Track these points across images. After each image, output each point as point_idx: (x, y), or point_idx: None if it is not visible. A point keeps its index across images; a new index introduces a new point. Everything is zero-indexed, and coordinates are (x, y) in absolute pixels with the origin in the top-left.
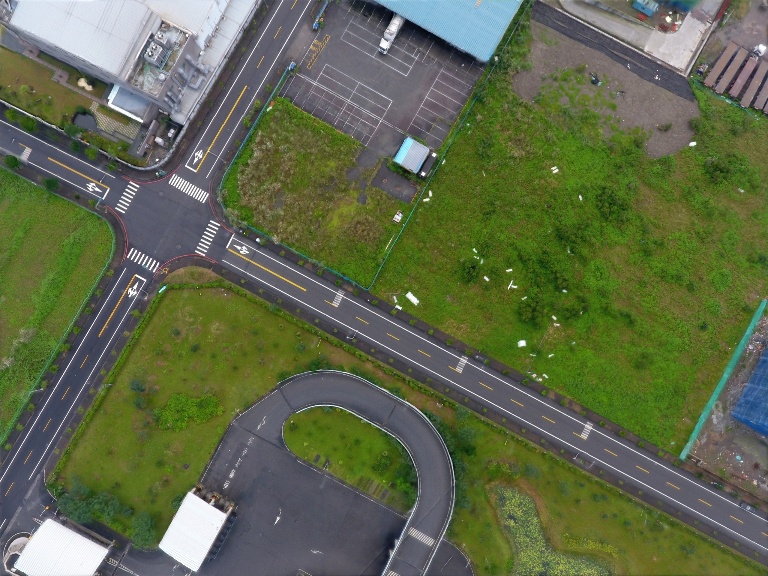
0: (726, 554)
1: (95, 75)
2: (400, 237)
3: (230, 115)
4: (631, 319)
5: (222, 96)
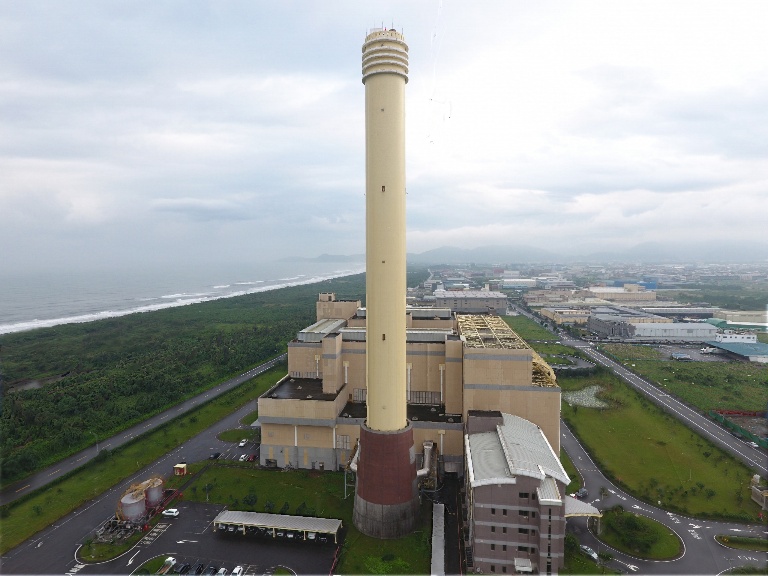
0: None
1: (597, 331)
2: None
3: None
4: None
5: None
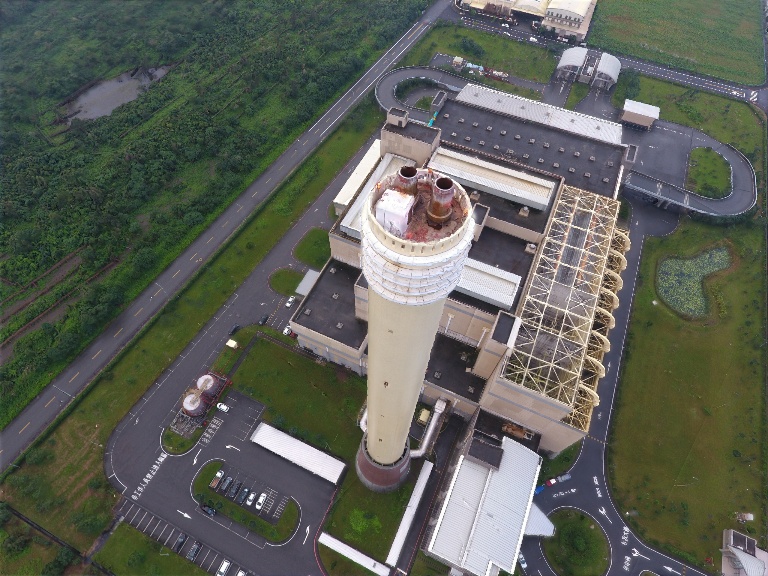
0: (761, 398)
1: None
2: None
3: None
4: None
5: None
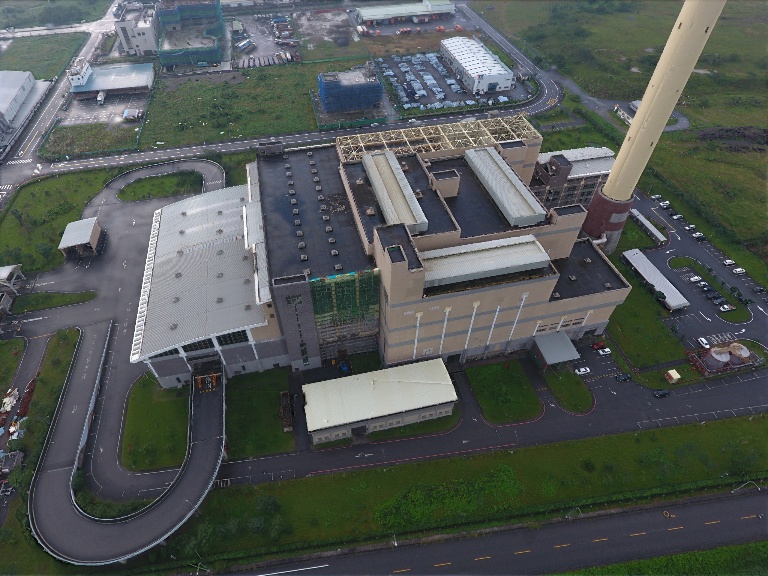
0: None
1: None
2: (142, 132)
3: (33, 139)
4: (261, 110)
5: (26, 137)
